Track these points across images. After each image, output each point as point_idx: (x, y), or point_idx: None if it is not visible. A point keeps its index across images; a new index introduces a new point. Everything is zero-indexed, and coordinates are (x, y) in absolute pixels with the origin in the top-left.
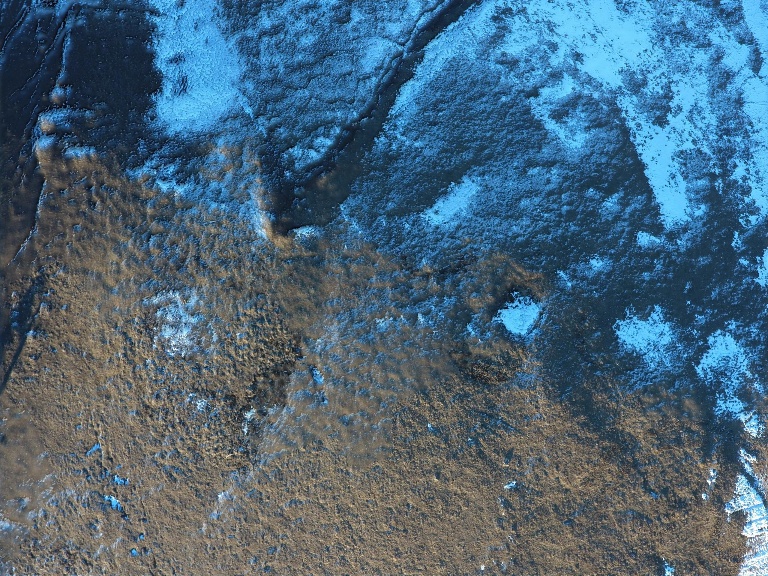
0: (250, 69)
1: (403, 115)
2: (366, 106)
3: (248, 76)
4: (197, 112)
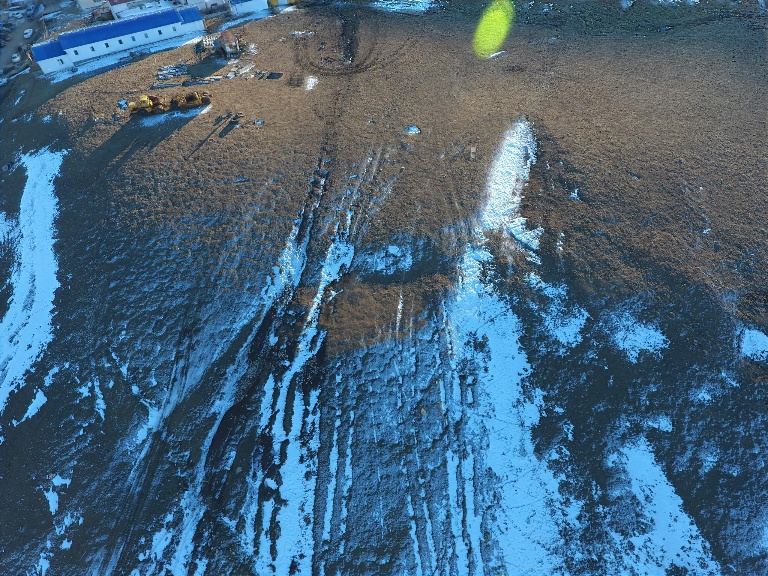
0: None
1: None
2: None
3: None
4: None
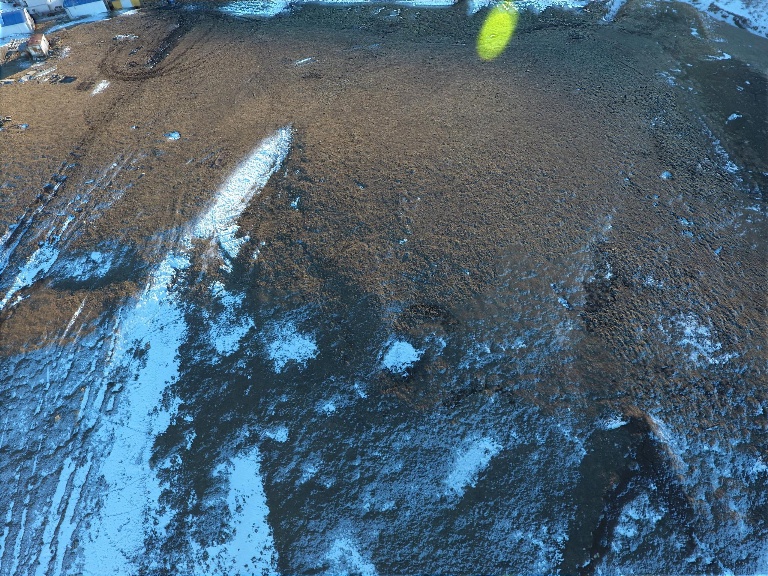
0: None
1: (542, 575)
2: None
3: None
4: None
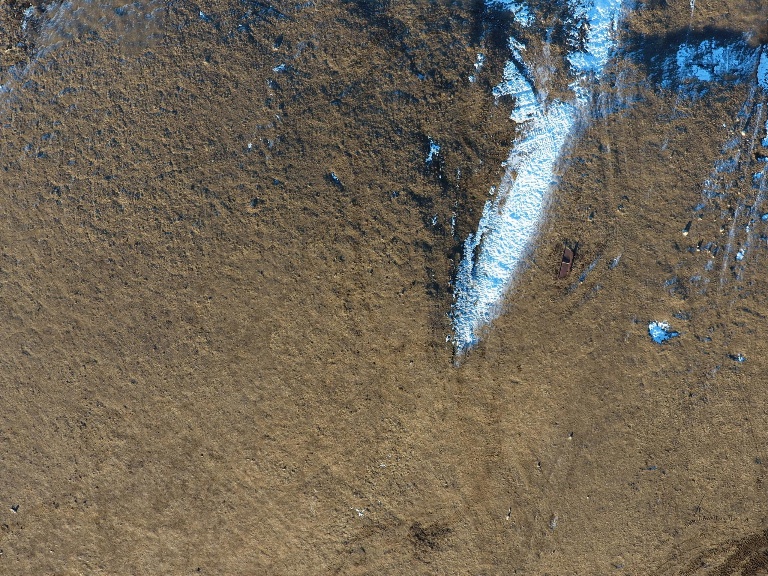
0: None
1: None
2: None
3: None
4: None
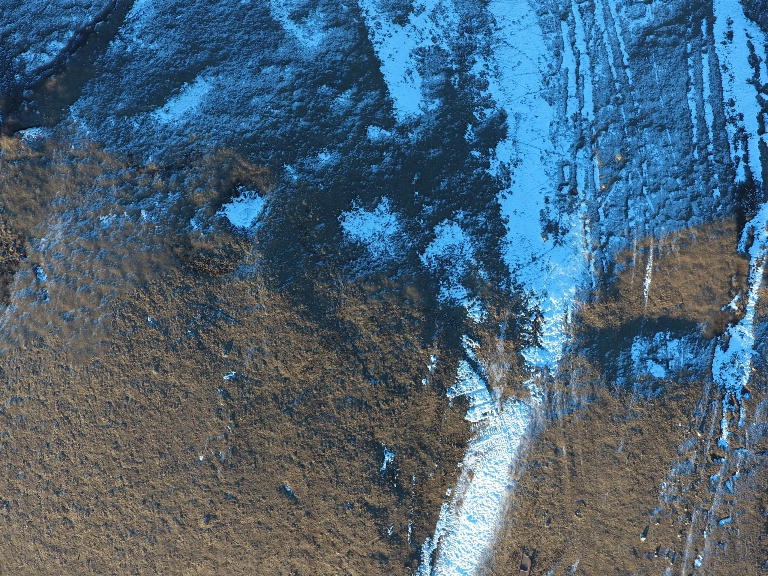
0: None
1: (141, 19)
2: (102, 10)
3: None
4: None
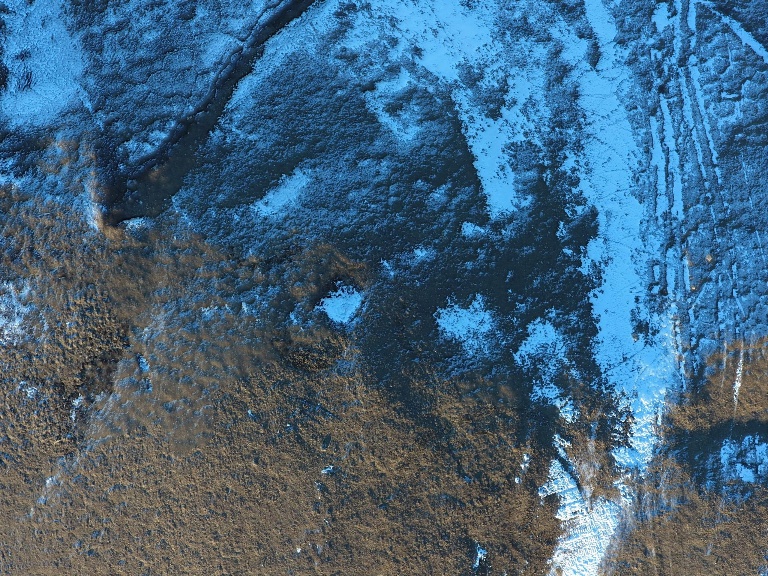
0: (92, 65)
1: (239, 109)
2: (202, 100)
3: (90, 72)
4: (39, 107)
